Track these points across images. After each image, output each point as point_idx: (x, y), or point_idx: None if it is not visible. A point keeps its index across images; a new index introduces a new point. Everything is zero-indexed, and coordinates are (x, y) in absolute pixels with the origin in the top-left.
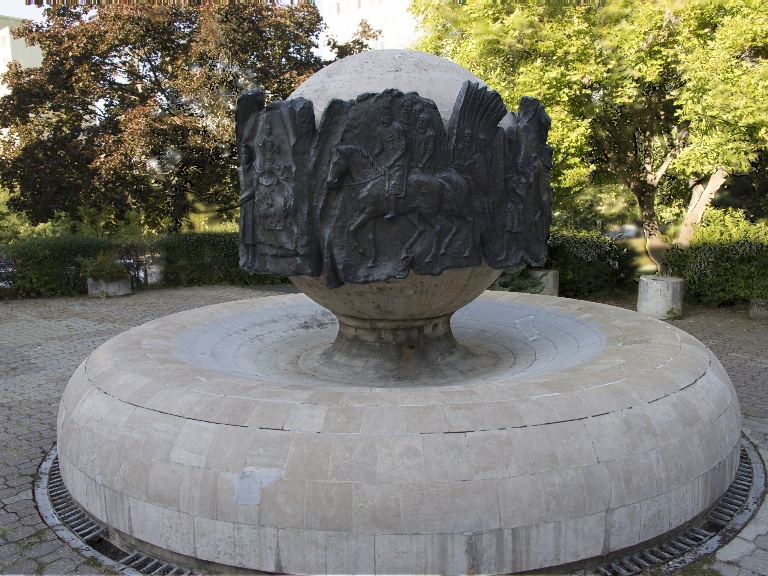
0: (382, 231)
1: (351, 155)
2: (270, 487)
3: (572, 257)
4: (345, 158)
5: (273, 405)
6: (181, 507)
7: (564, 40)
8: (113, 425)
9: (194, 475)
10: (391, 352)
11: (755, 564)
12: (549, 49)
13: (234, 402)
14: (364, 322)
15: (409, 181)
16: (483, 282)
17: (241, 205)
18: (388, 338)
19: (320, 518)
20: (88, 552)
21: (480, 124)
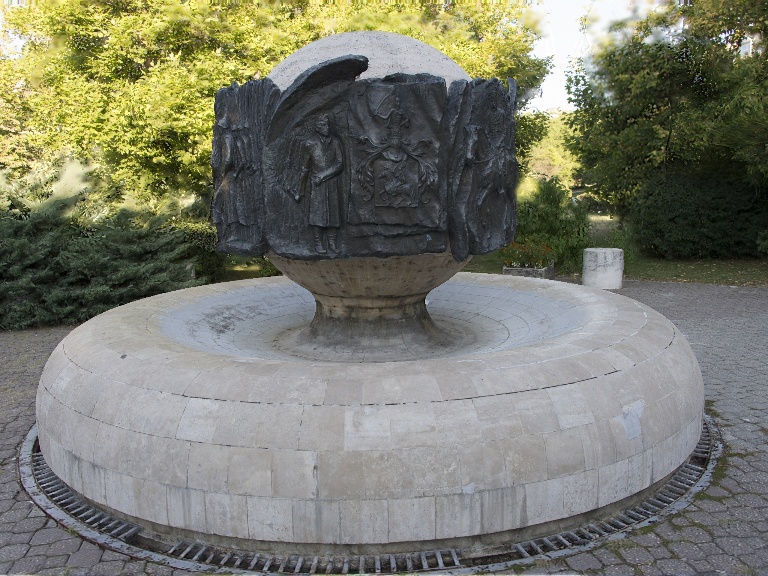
0: (492, 205)
1: (480, 135)
2: (643, 416)
3: (196, 248)
4: None
5: (584, 357)
6: (587, 466)
7: (246, 35)
8: (462, 426)
9: (591, 432)
10: (417, 325)
11: (708, 392)
12: (229, 41)
13: (557, 364)
14: (395, 300)
15: (506, 161)
16: None
17: (320, 183)
18: (411, 312)
19: (670, 427)
20: (493, 568)
21: None
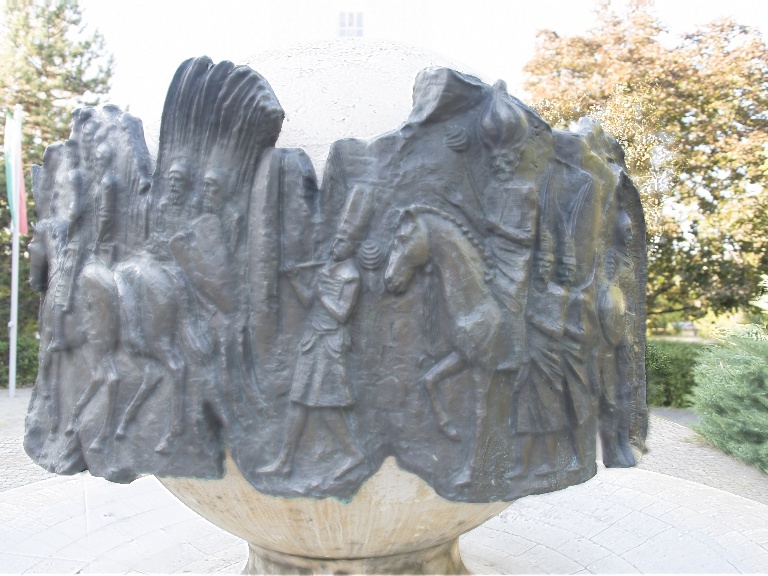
0: (64, 374)
1: (44, 234)
2: None
3: None
4: (40, 240)
5: None
6: None
7: None
8: None
9: None
10: None
11: None
12: None
13: None
14: None
15: (79, 279)
16: (359, 510)
17: None
18: (260, 572)
19: None
20: None
21: (213, 148)
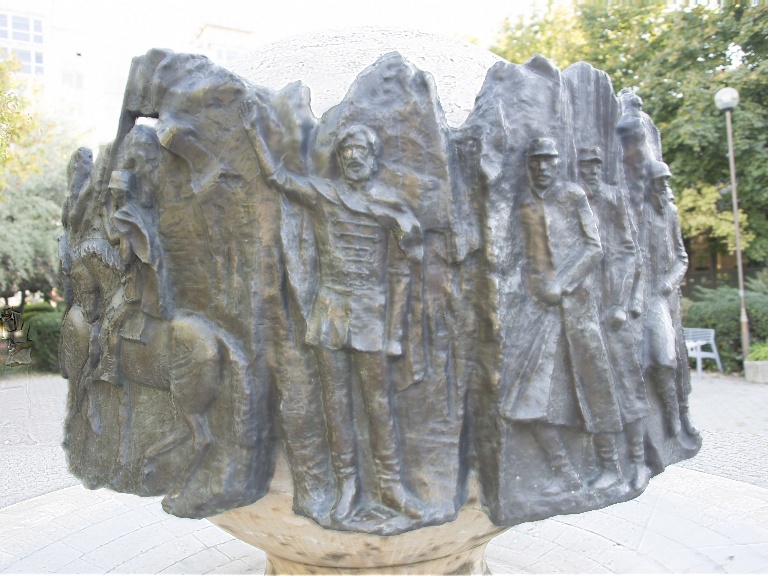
0: None
1: None
2: None
3: None
4: None
5: None
6: None
7: None
8: None
9: None
10: None
11: None
12: None
13: None
14: None
15: None
16: None
17: None
18: None
19: None
20: None
21: None
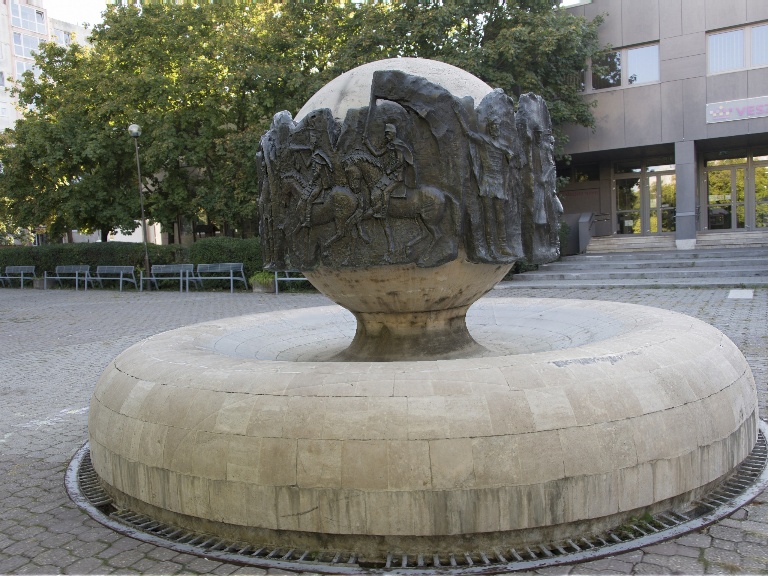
0: None
1: None
2: None
3: None
4: None
5: None
6: None
7: None
8: None
9: None
10: None
11: None
12: None
13: None
14: None
15: None
16: None
17: None
18: None
19: None
20: None
21: None
